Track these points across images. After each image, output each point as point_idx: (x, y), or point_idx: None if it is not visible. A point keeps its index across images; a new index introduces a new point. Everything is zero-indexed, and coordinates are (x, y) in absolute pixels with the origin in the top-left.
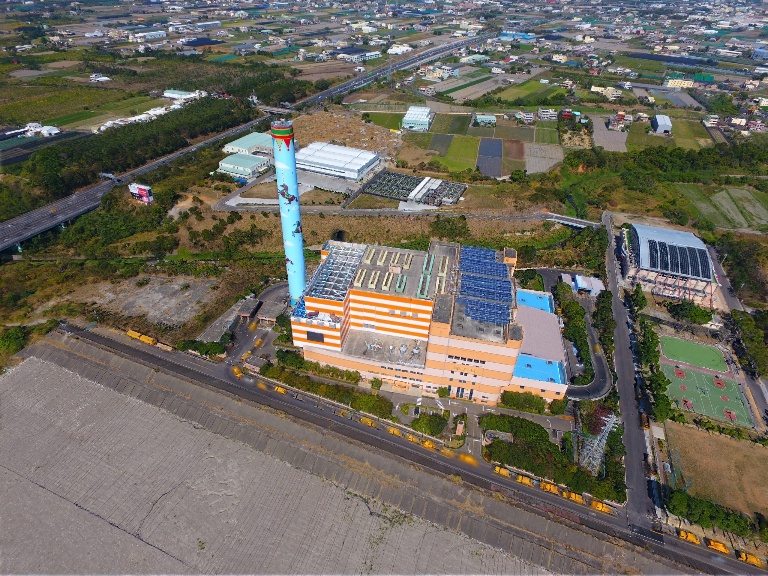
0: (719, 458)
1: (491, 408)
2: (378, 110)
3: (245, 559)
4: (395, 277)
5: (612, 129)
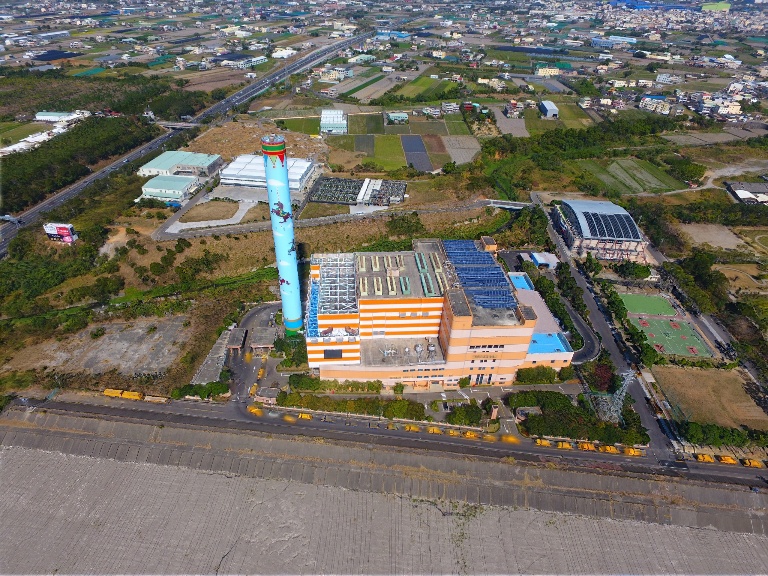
0: (699, 387)
1: (509, 388)
2: (289, 116)
3: None
4: (396, 280)
5: (510, 117)
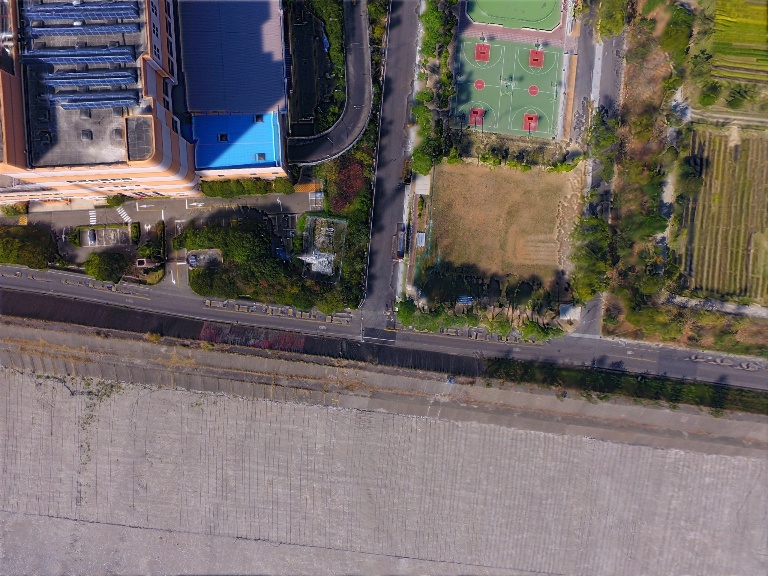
0: (491, 206)
1: (198, 201)
2: None
3: None
4: None
5: None
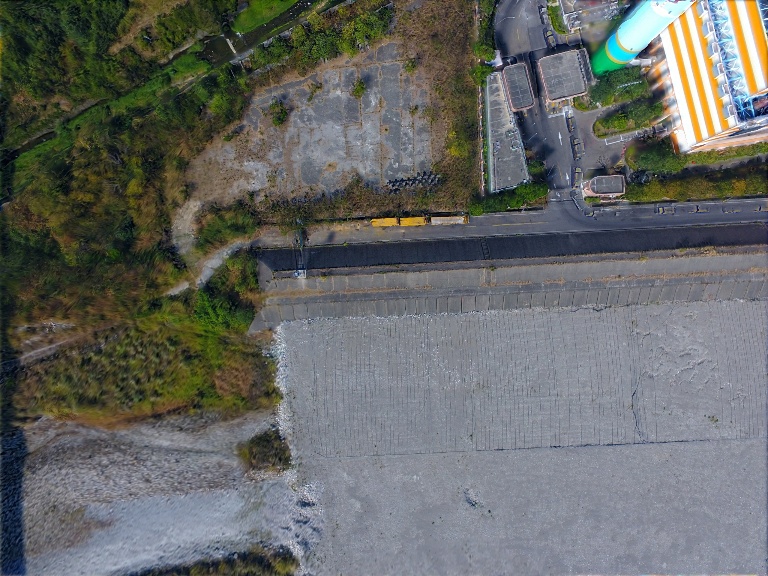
0: None
1: None
2: None
3: (764, 410)
4: None
5: None
